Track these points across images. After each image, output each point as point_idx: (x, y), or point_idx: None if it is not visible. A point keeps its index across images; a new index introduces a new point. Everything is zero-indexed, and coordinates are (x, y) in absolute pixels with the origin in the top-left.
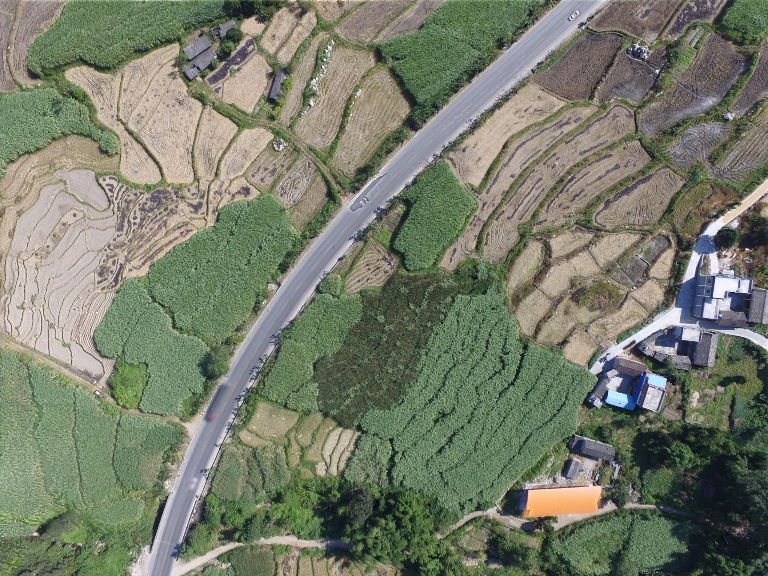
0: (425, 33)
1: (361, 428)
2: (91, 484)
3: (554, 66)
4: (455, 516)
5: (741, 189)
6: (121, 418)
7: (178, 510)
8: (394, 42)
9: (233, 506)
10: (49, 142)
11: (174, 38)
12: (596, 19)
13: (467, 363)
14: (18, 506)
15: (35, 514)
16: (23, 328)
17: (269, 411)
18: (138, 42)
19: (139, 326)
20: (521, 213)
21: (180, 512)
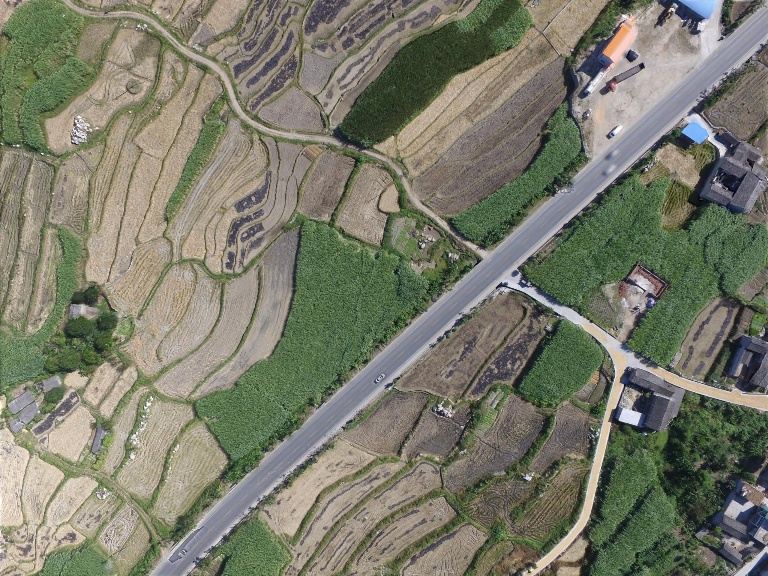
0: (238, 394)
1: None
2: None
3: (363, 423)
4: None
5: (541, 545)
6: None
7: None
8: (208, 403)
9: None
10: None
11: None
12: (402, 380)
13: None
14: None
15: None
16: None
17: None
18: None
19: None
20: (333, 564)
21: None
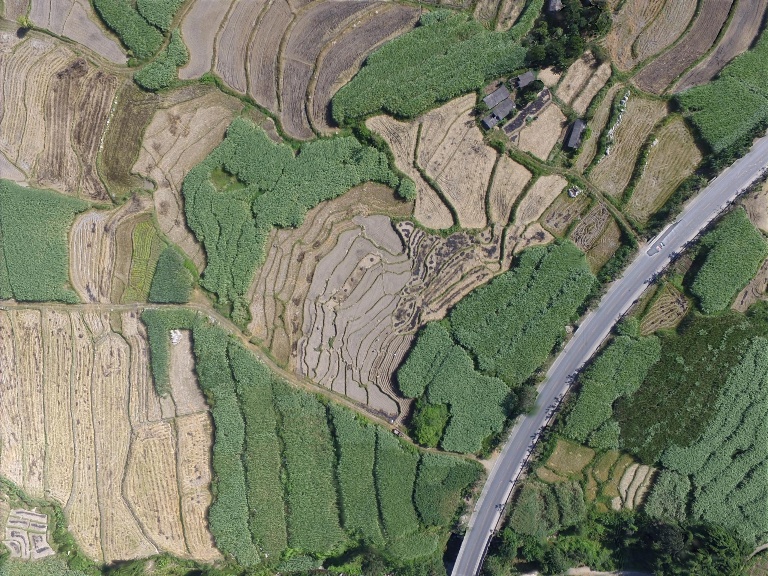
0: (722, 85)
1: (662, 465)
2: (394, 521)
3: None
4: (750, 547)
5: None
6: (423, 457)
7: (473, 544)
8: (692, 94)
9: (531, 540)
10: (348, 189)
11: (474, 88)
12: None
13: (765, 402)
14: (315, 542)
15: (330, 549)
16: (320, 370)
17: (567, 448)
18: (442, 93)
19: (444, 368)
20: None
21: (475, 546)
